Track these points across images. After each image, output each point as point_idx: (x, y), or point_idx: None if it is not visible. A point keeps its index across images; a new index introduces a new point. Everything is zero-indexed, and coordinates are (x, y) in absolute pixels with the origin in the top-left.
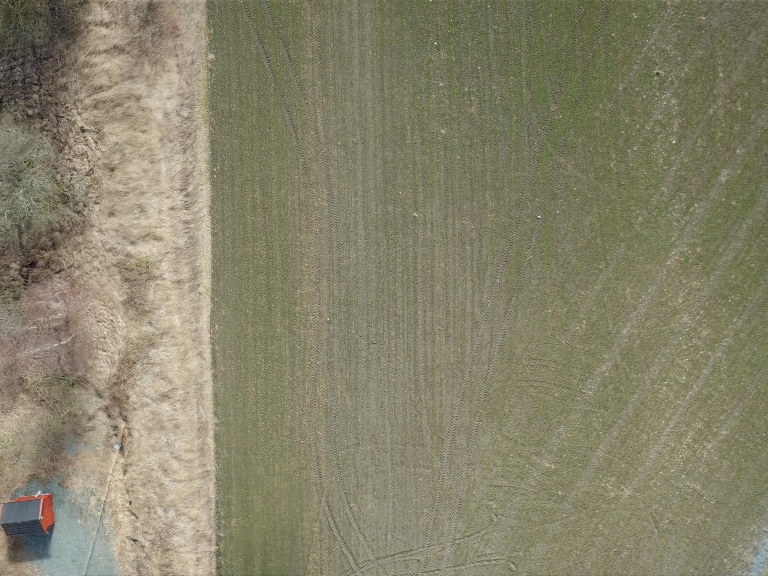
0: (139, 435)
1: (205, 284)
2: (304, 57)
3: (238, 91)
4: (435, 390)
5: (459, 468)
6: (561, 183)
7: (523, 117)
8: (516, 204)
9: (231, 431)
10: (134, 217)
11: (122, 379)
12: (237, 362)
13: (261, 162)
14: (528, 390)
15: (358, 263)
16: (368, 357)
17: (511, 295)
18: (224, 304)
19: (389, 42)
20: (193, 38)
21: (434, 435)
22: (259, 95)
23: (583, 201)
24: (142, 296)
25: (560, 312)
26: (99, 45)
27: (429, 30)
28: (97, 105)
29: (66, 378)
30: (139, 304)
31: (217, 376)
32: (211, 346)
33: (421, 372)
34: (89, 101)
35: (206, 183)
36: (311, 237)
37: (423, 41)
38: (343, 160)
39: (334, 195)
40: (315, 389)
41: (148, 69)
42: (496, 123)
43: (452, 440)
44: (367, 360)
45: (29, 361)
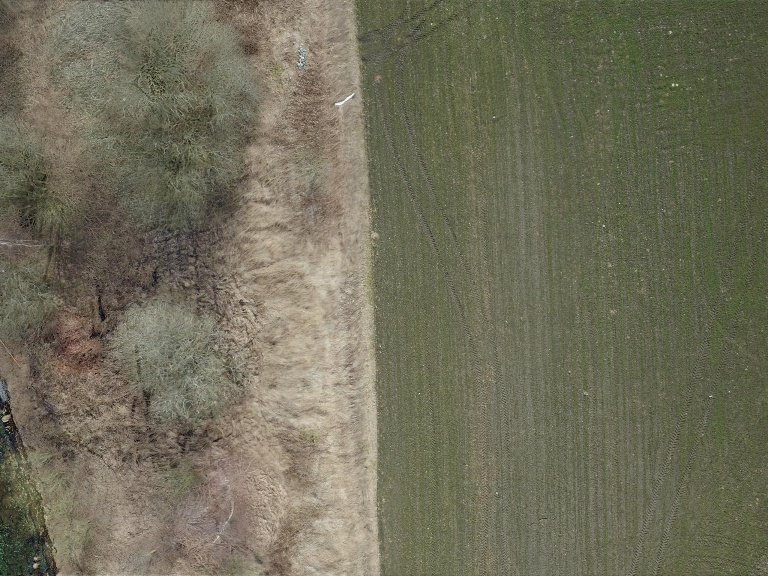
0: None
1: (371, 458)
2: (469, 236)
3: (403, 269)
4: (608, 565)
5: None
6: (732, 364)
7: (693, 299)
8: (687, 384)
9: None
10: (297, 391)
11: (284, 547)
12: (405, 535)
13: (427, 339)
14: (702, 566)
15: (527, 439)
16: (539, 531)
17: (683, 473)
18: (391, 478)
19: (557, 224)
20: (356, 217)
21: None
22: (424, 273)
23: (755, 381)
24: (306, 468)
25: (733, 490)
26: (260, 222)
27: (597, 213)
28: (257, 280)
29: (225, 544)
30: (302, 475)
31: (384, 548)
32: (378, 518)
33: (593, 547)
34: (249, 275)
35: (371, 359)
36: (479, 413)
37: (591, 223)
38: (510, 338)
39: (502, 372)
40: (484, 562)
41: (311, 247)
42: (666, 304)
43: None
44: (537, 534)
45: (186, 527)
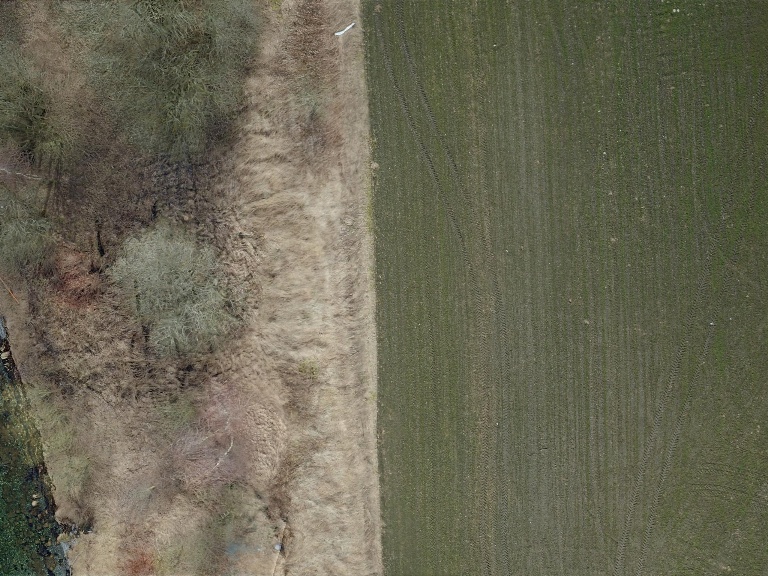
0: (302, 536)
1: (371, 389)
2: (470, 166)
3: (403, 199)
4: (608, 494)
5: (633, 571)
6: (734, 291)
7: (694, 226)
8: (688, 311)
9: (399, 534)
10: (297, 323)
11: (284, 481)
12: (405, 466)
13: (427, 269)
14: (703, 494)
15: (528, 369)
16: (539, 461)
17: (684, 401)
18: (391, 409)
19: (557, 152)
20: (356, 147)
21: (608, 538)
22: (424, 203)
23: (756, 308)
24: (306, 401)
25: (734, 417)
26: (260, 153)
27: (598, 140)
28: (257, 212)
29: (224, 479)
30: (302, 408)
31: (384, 480)
32: (378, 450)
33: (594, 476)
34: (248, 208)
35: (371, 290)
36: (479, 343)
37: (592, 151)
38: (511, 267)
39: (502, 302)
40: (485, 493)
41: (311, 177)
42: (667, 232)
43: (626, 543)
44: (538, 464)
45: (186, 463)
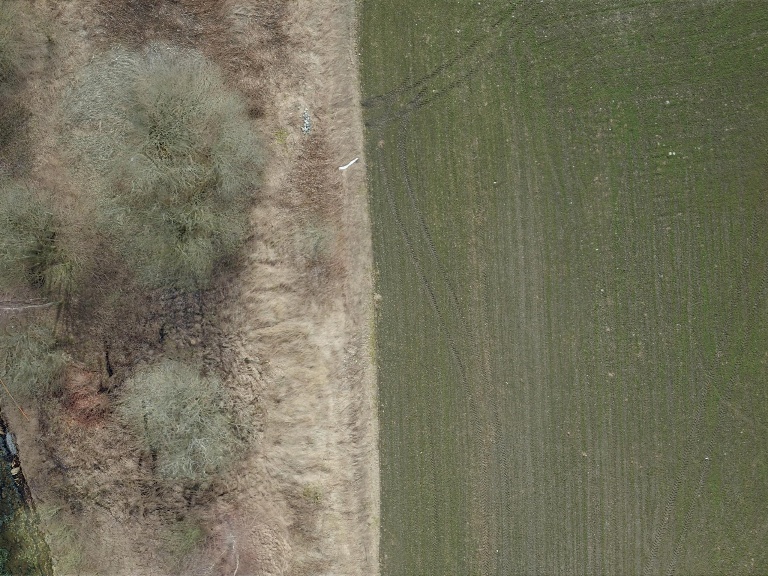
0: None
1: (374, 515)
2: (471, 299)
3: (405, 330)
4: None
5: None
6: (728, 427)
7: (690, 363)
8: (684, 446)
9: None
10: (301, 448)
11: None
12: None
13: (429, 399)
14: None
15: (527, 498)
16: None
17: (680, 533)
18: (393, 534)
19: (556, 288)
20: (360, 279)
21: None
22: (426, 335)
23: (750, 444)
24: (310, 524)
25: (729, 550)
26: (265, 283)
27: (596, 278)
28: (262, 339)
29: None
30: (306, 531)
31: None
32: (380, 574)
33: None
34: (254, 334)
35: (374, 418)
36: (479, 472)
37: (590, 288)
38: (511, 399)
39: (502, 432)
40: None
41: (315, 308)
42: (663, 368)
43: None
44: None
45: None
